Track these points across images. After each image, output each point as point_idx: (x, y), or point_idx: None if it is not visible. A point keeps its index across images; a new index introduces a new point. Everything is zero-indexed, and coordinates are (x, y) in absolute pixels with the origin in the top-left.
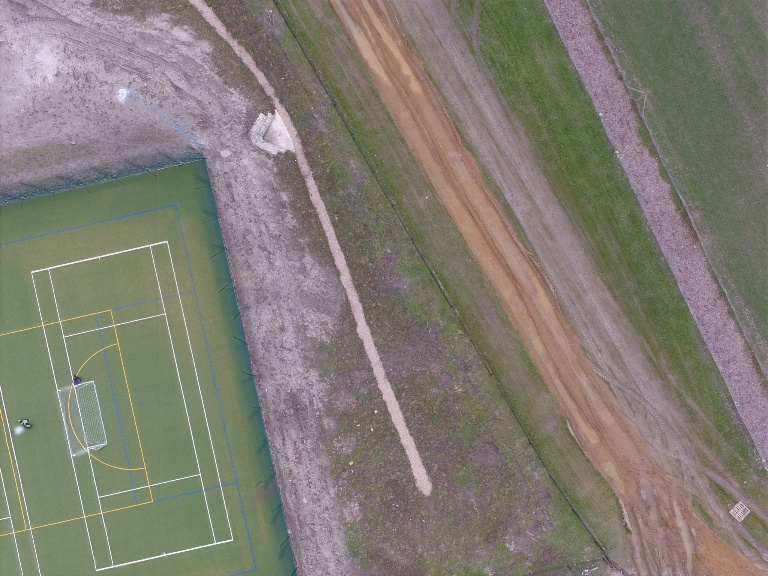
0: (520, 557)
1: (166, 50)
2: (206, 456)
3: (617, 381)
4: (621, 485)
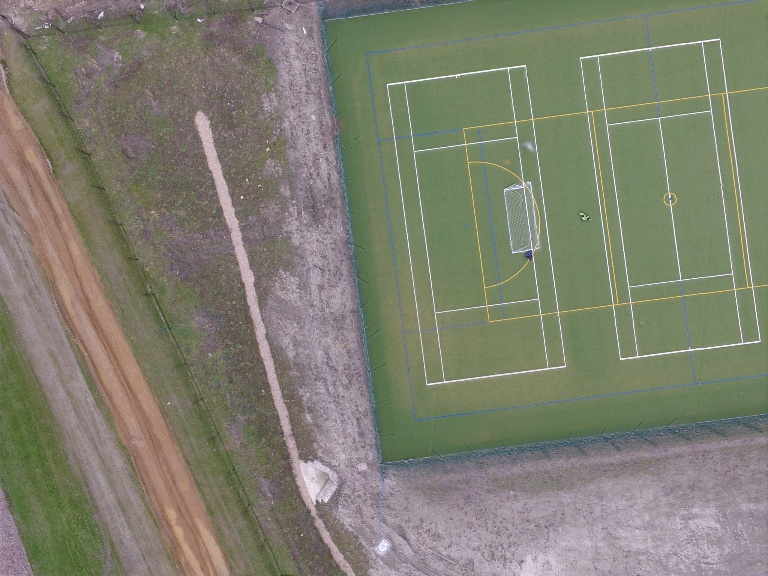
0: (109, 45)
1: (411, 575)
2: (407, 169)
3: (1, 208)
4: (7, 107)
